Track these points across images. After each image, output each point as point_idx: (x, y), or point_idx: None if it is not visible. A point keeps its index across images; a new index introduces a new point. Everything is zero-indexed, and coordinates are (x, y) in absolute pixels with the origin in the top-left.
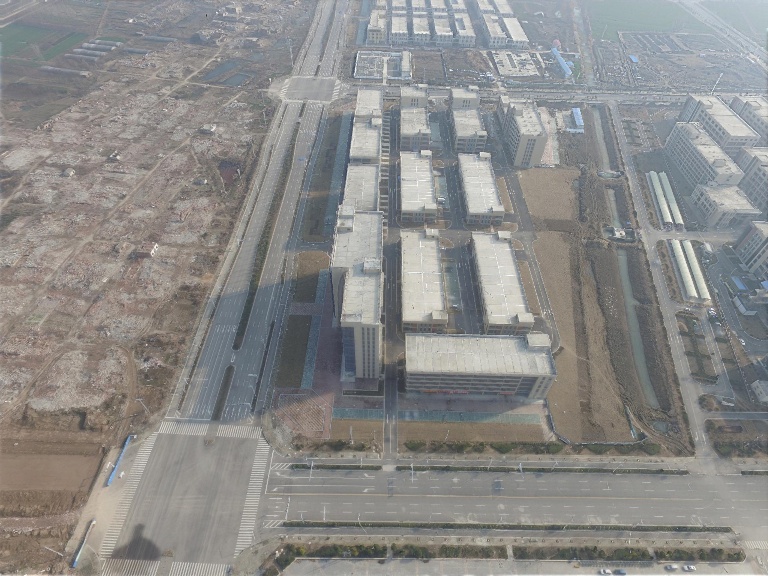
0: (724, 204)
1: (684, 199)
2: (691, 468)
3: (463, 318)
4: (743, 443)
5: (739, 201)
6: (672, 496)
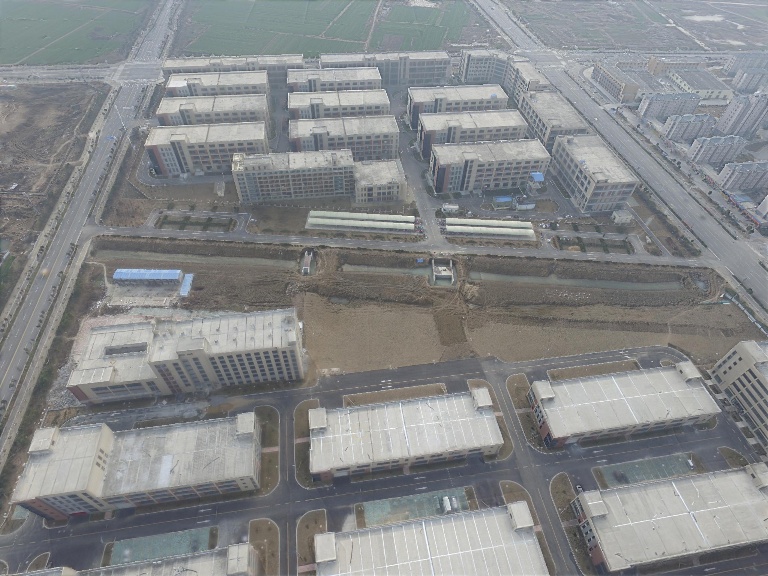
0: (392, 178)
1: (358, 207)
2: (728, 273)
3: (700, 451)
4: (679, 240)
5: (383, 167)
6: (763, 288)
